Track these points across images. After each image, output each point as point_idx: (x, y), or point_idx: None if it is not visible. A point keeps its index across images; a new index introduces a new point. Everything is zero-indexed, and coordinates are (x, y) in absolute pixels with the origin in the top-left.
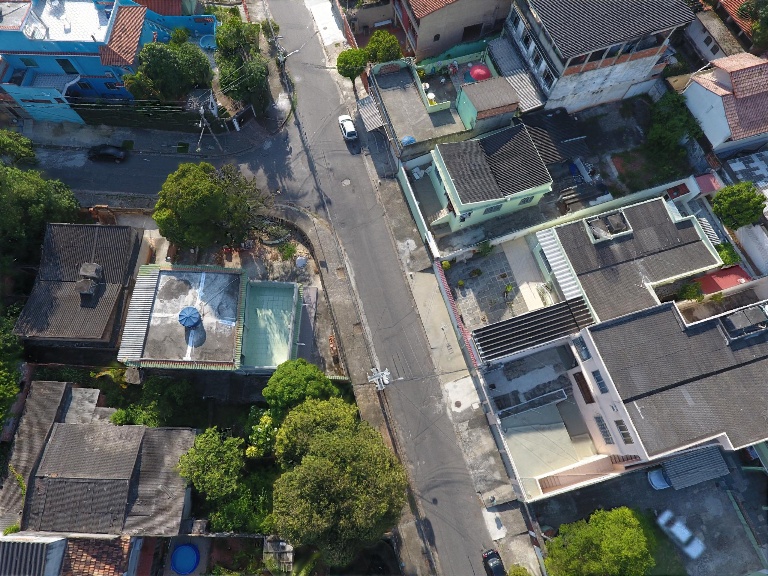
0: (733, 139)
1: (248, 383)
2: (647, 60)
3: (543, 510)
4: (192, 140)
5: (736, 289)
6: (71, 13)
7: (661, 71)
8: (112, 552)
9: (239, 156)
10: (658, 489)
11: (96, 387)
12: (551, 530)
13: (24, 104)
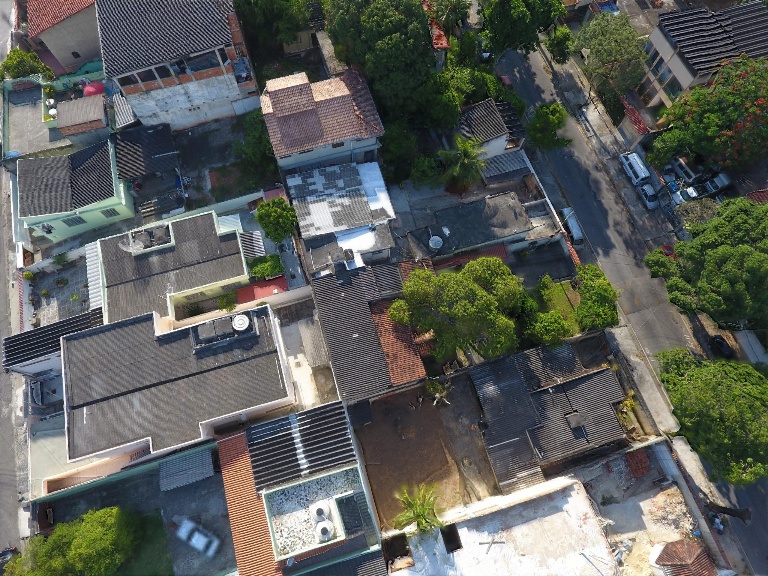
0: (275, 156)
1: None
2: (221, 79)
3: (72, 510)
4: None
5: (293, 299)
6: None
7: (255, 89)
8: None
9: None
10: (168, 490)
11: None
12: None
13: None
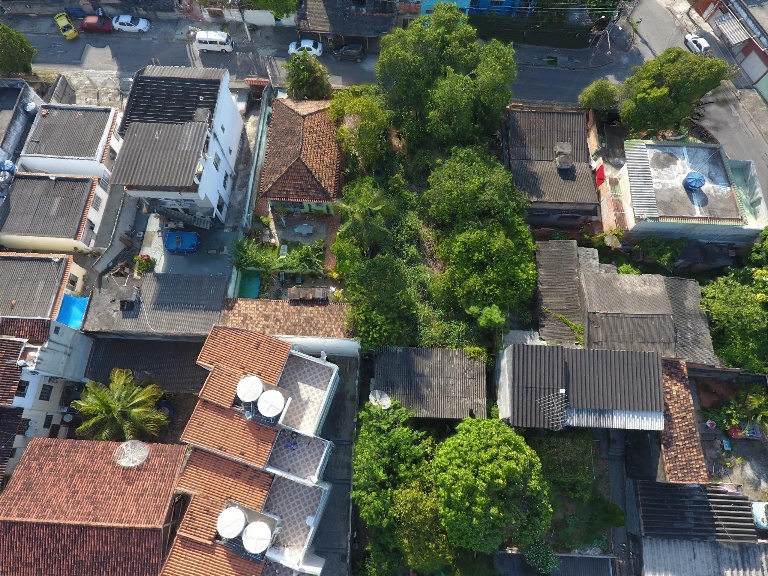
0: None
1: (710, 250)
2: None
3: None
4: (559, 54)
5: None
6: None
7: None
8: (677, 373)
9: (603, 69)
10: None
11: None
12: None
13: None
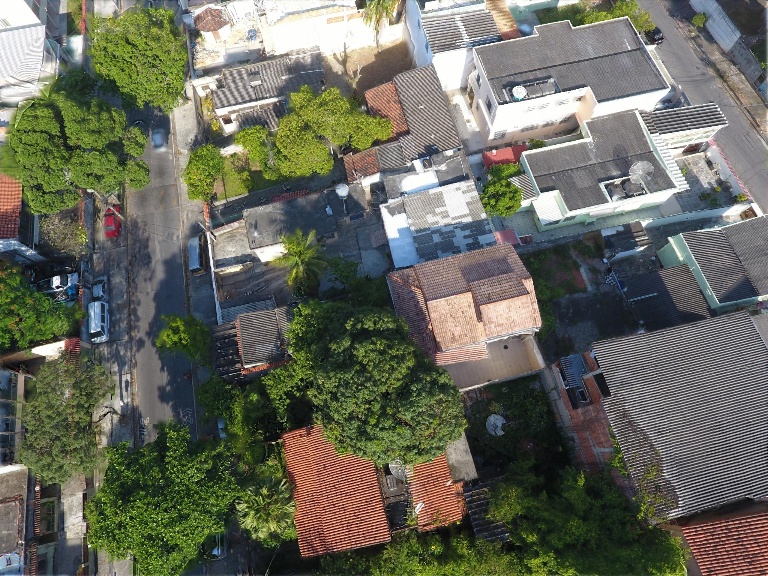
0: None
1: None
2: None
3: None
4: None
5: None
6: None
7: None
8: None
9: None
10: None
11: None
12: None
13: None
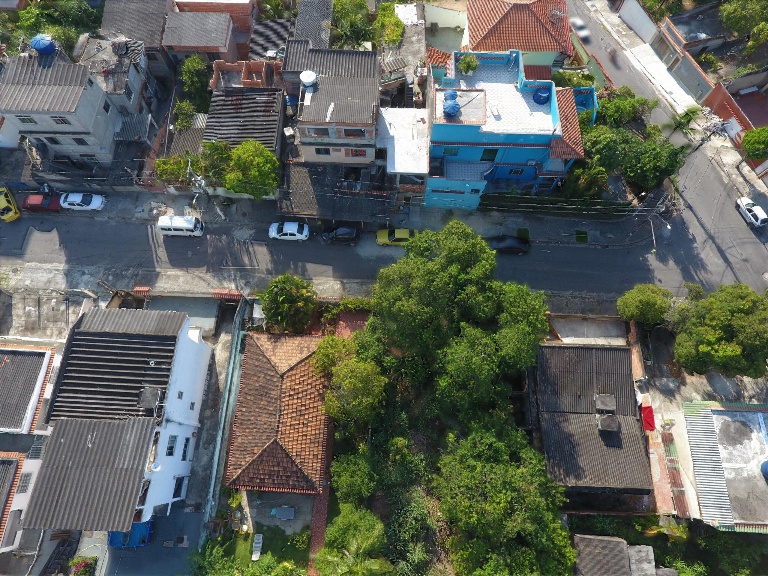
0: None
1: None
2: None
3: None
4: (589, 227)
5: None
6: (493, 96)
7: None
8: None
9: (642, 245)
10: None
11: (627, 538)
12: None
13: (430, 194)
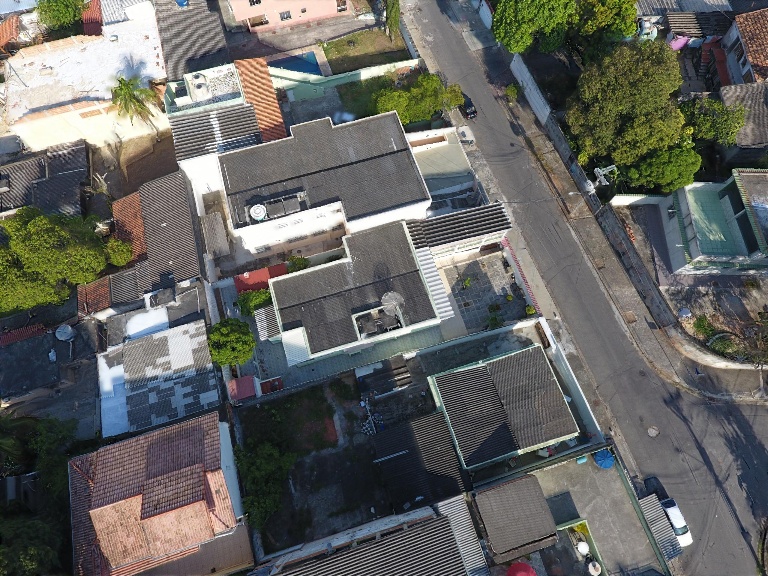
0: None
1: None
2: None
3: None
4: None
5: None
6: None
7: None
8: (766, 72)
9: None
10: None
11: None
12: (434, 121)
13: None
